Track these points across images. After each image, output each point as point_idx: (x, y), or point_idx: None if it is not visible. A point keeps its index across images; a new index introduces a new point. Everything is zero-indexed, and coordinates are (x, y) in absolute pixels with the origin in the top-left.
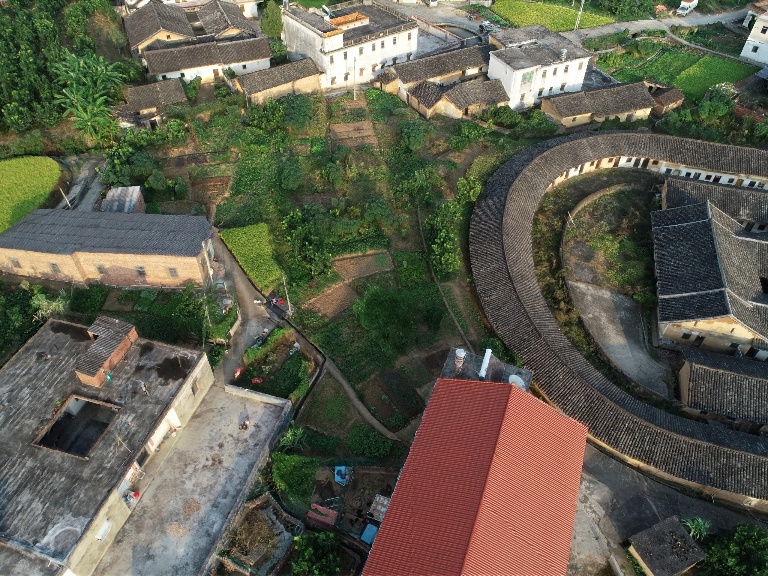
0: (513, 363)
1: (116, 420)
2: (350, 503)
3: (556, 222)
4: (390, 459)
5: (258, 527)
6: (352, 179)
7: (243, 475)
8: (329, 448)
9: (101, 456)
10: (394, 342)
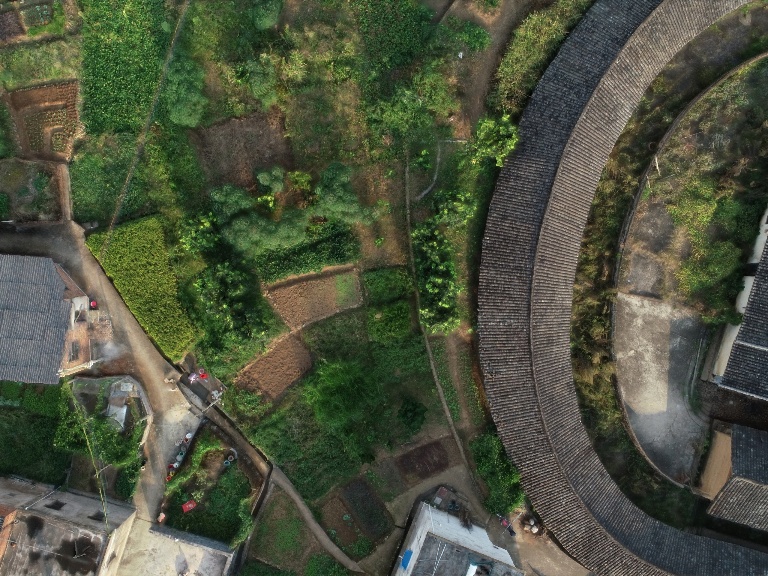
0: (509, 475)
1: None
2: None
3: (630, 178)
4: None
5: None
6: (294, 78)
7: None
8: None
9: None
10: (360, 437)
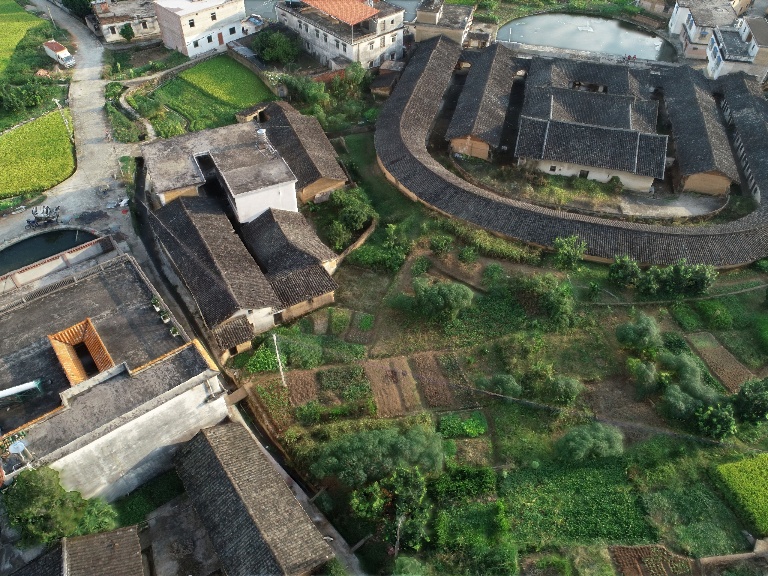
0: None
1: None
2: None
3: None
4: None
5: None
6: None
7: None
8: None
9: None
10: None
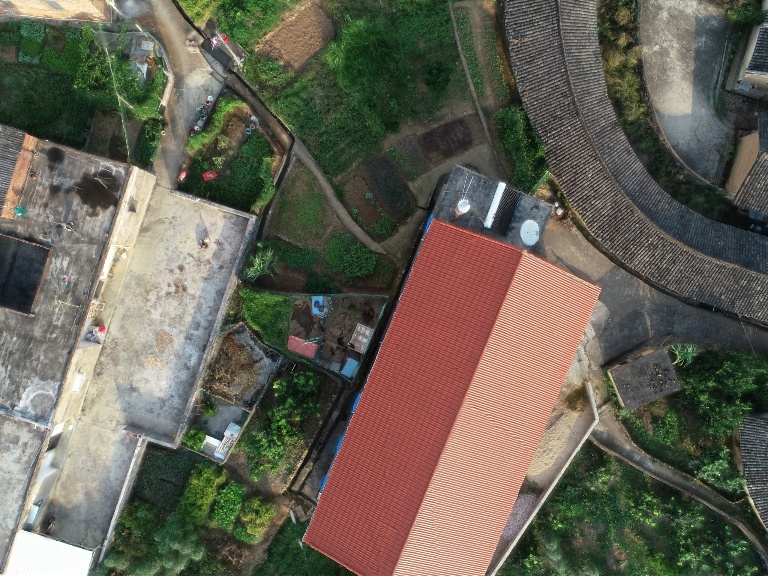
0: (534, 149)
1: (49, 265)
2: (330, 330)
3: None
4: (373, 278)
5: (236, 361)
6: None
7: (212, 304)
8: (305, 266)
9: (47, 312)
10: (383, 111)
